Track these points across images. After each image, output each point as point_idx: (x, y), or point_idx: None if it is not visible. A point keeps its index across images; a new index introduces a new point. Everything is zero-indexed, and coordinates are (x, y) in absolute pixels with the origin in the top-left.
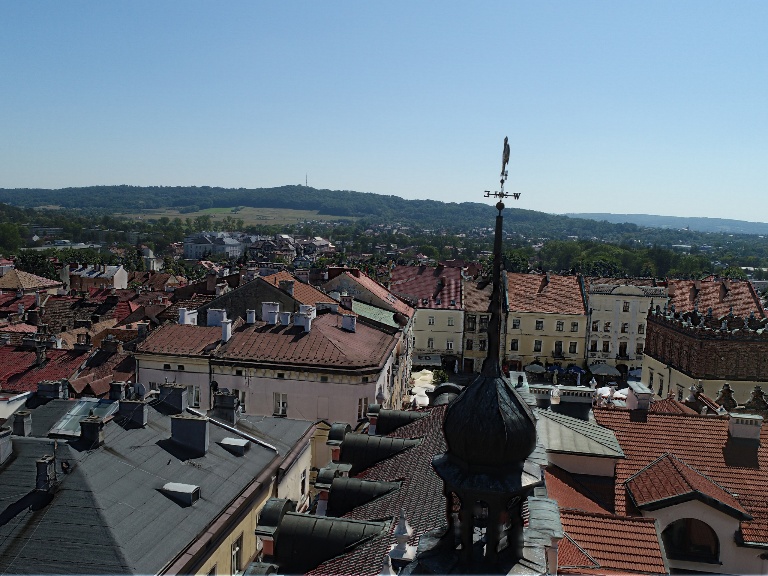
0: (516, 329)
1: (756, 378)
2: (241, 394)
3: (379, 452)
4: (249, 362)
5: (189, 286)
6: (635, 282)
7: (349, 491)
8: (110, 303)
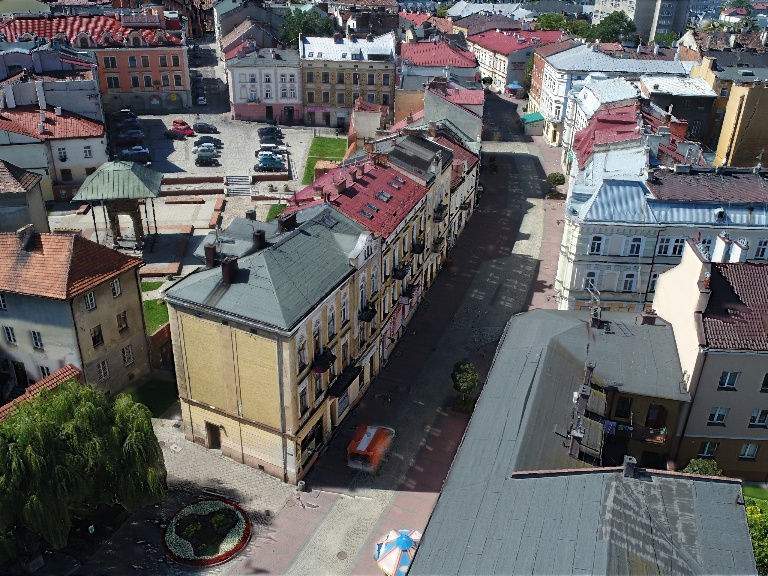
0: None
1: None
2: None
3: None
4: None
5: None
6: None
7: None
8: None
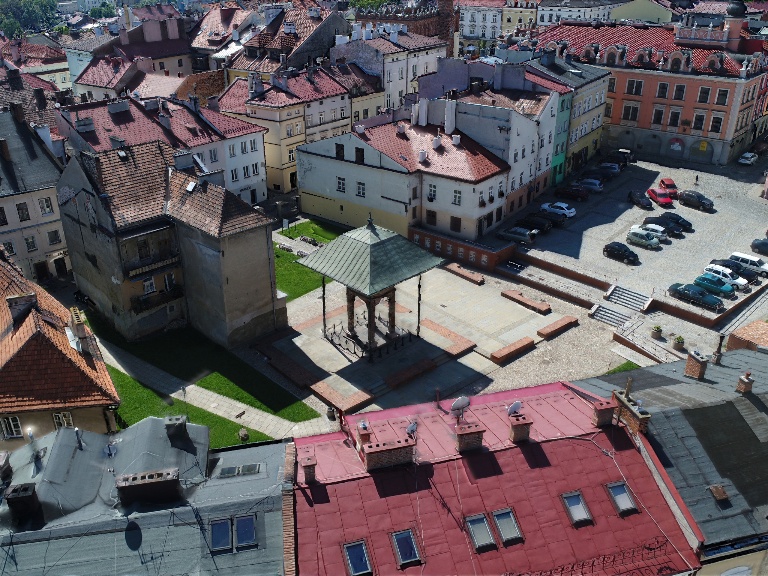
0: None
1: None
2: None
3: None
4: (421, 49)
5: (105, 44)
6: (265, 1)
7: None
8: (14, 78)
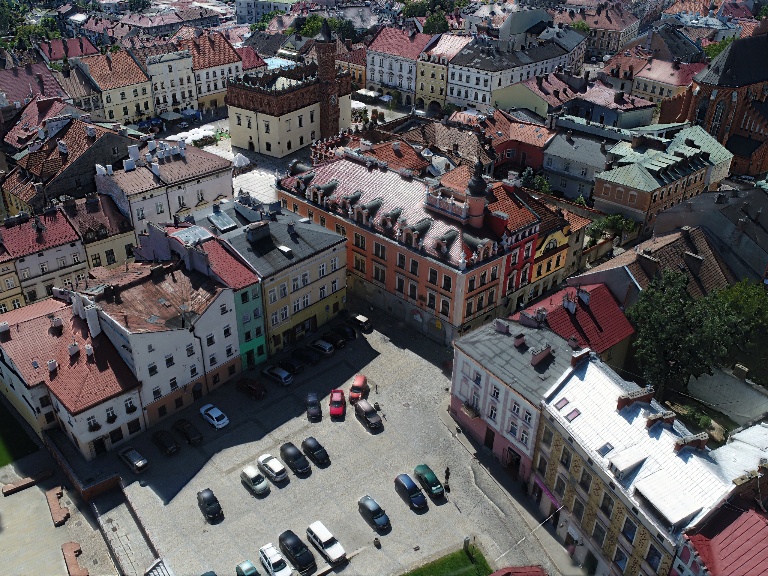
0: (109, 103)
1: (297, 108)
2: (182, 197)
3: (331, 189)
4: (186, 180)
5: None
6: (163, 48)
7: (353, 199)
8: None
